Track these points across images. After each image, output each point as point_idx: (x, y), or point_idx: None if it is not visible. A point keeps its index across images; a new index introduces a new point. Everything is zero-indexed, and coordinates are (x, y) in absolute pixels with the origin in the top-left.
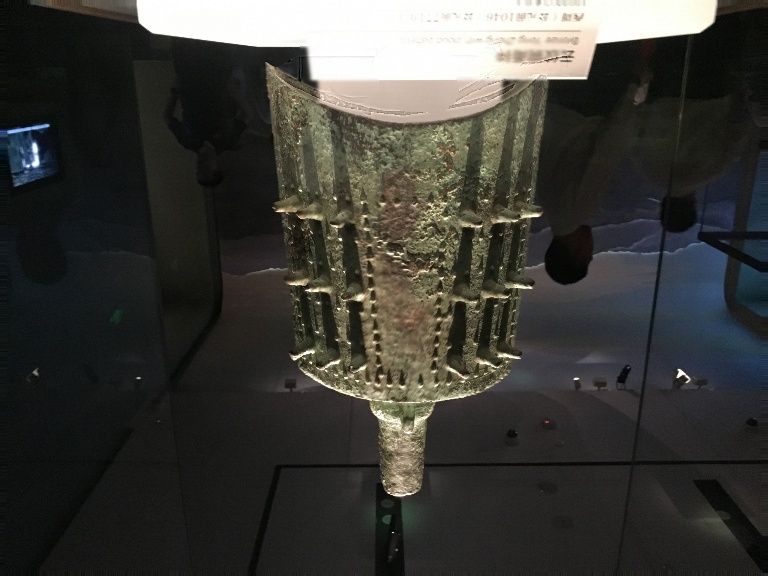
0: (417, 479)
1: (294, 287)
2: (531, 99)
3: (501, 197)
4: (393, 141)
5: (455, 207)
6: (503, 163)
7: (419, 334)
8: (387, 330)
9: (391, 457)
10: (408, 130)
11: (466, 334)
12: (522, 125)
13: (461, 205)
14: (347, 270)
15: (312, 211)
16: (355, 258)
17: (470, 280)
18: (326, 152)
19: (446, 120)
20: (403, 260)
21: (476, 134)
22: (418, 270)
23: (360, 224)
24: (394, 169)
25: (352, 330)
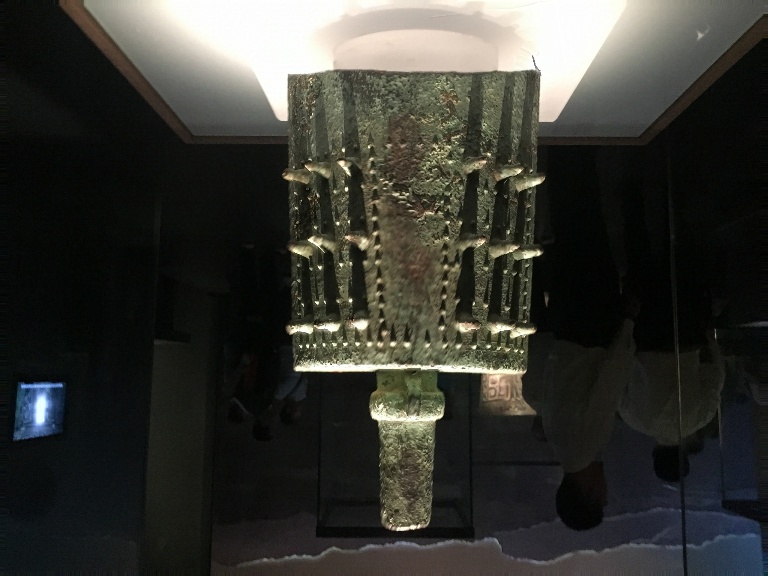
0: (424, 506)
1: (296, 270)
2: (525, 85)
3: (503, 159)
4: (400, 87)
5: (459, 153)
6: (503, 127)
7: (425, 282)
8: (391, 278)
9: (394, 472)
10: (413, 77)
11: (475, 291)
12: (519, 102)
13: (465, 152)
14: (352, 219)
15: (320, 164)
16: (360, 204)
17: (477, 232)
18: (337, 110)
19: (448, 72)
20: (408, 201)
21: (476, 90)
22: (424, 211)
23: (367, 168)
24: (400, 112)
25: (354, 285)
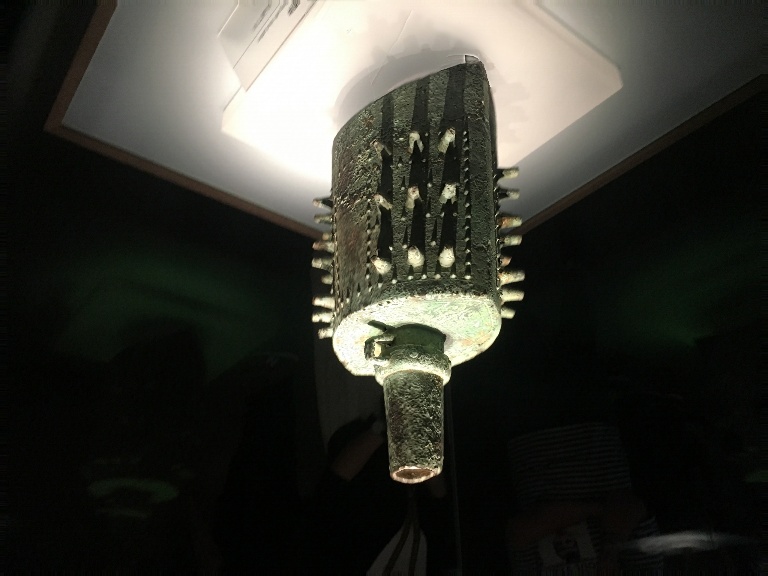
0: (412, 448)
1: None
2: (448, 77)
3: None
4: (342, 135)
5: None
6: (417, 115)
7: None
8: (341, 259)
9: None
10: None
11: (394, 239)
12: (438, 92)
13: None
14: None
15: None
16: None
17: (393, 196)
18: None
19: None
20: None
21: (387, 104)
22: (354, 202)
23: None
24: None
25: None
